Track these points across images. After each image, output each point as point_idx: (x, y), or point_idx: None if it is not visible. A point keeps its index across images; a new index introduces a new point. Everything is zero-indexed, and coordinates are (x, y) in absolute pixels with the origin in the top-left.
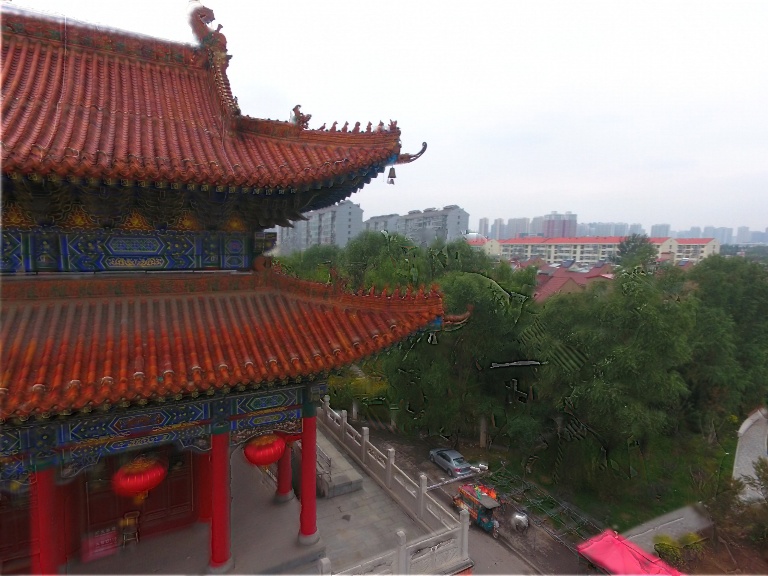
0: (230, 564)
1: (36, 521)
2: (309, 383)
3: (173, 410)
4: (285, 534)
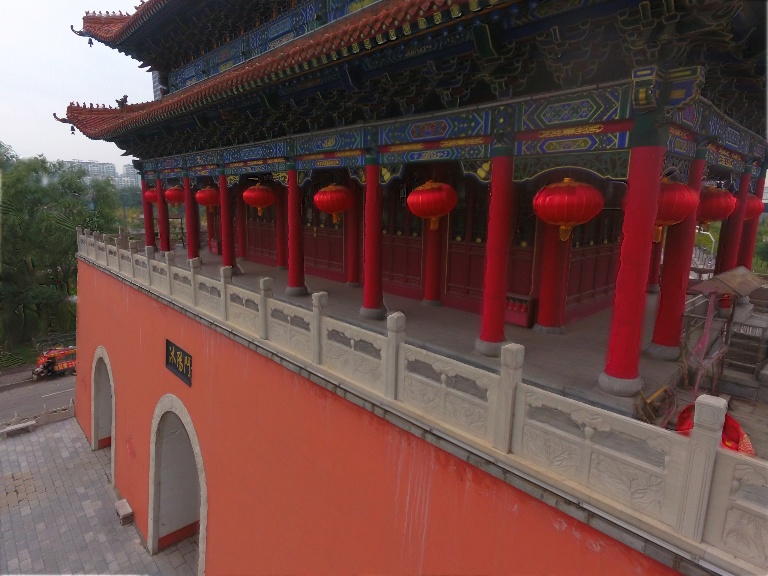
0: None
1: None
2: None
3: None
4: None
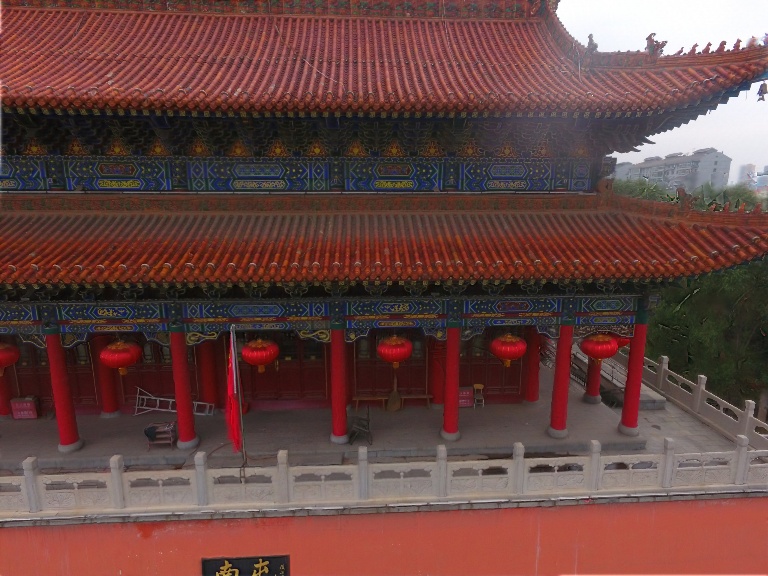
0: (566, 433)
1: (444, 367)
2: (645, 293)
3: (535, 301)
4: (604, 425)
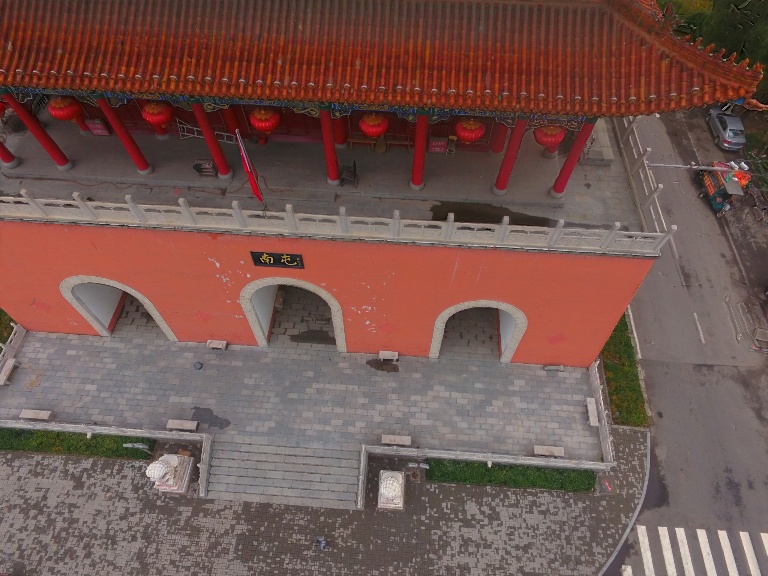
0: (505, 192)
1: (414, 141)
2: None
3: None
4: (542, 184)
